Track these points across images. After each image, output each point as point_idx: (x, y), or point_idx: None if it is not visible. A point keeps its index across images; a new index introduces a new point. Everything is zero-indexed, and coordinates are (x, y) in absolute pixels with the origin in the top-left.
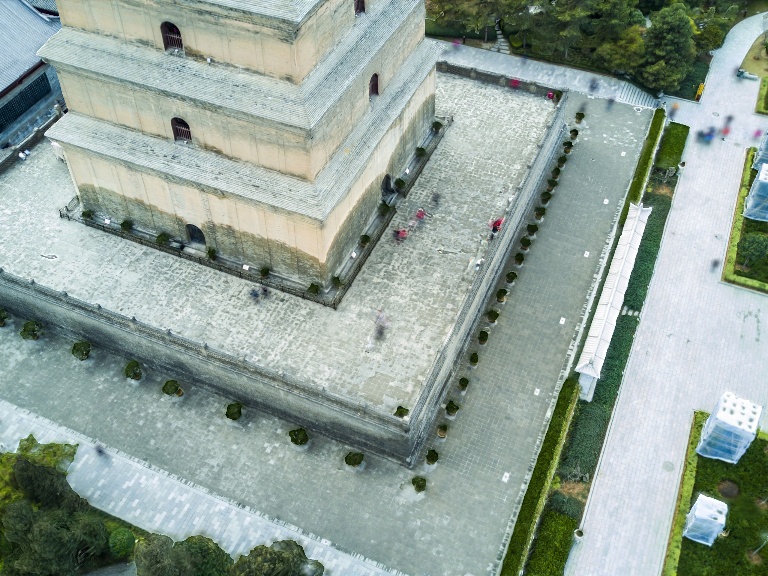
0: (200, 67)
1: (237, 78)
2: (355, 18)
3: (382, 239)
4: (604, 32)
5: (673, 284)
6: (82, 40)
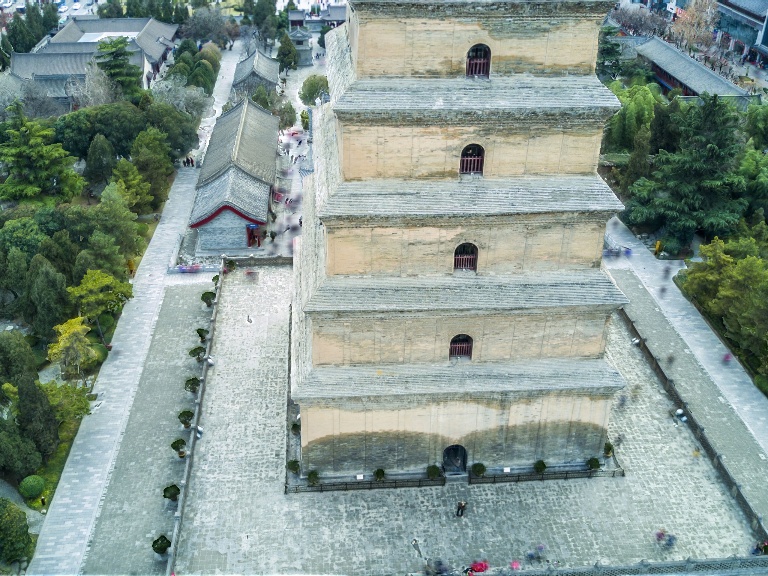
0: None
1: None
2: (457, 269)
3: (398, 490)
4: None
5: None
6: None
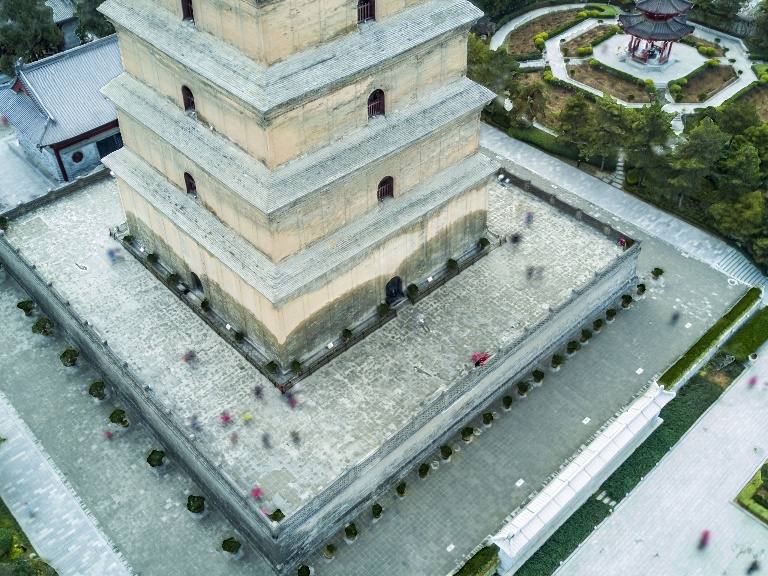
0: (205, 132)
1: (228, 150)
2: (369, 119)
3: (367, 339)
4: (726, 190)
5: (674, 485)
6: (133, 86)
